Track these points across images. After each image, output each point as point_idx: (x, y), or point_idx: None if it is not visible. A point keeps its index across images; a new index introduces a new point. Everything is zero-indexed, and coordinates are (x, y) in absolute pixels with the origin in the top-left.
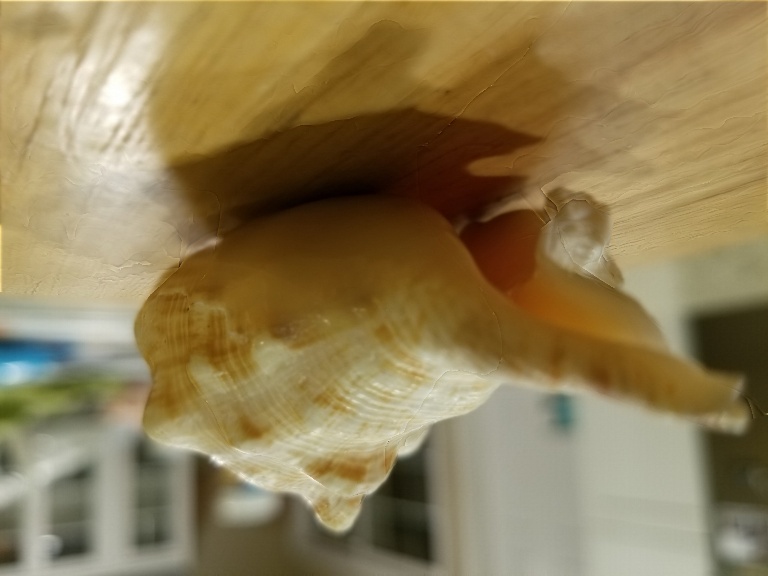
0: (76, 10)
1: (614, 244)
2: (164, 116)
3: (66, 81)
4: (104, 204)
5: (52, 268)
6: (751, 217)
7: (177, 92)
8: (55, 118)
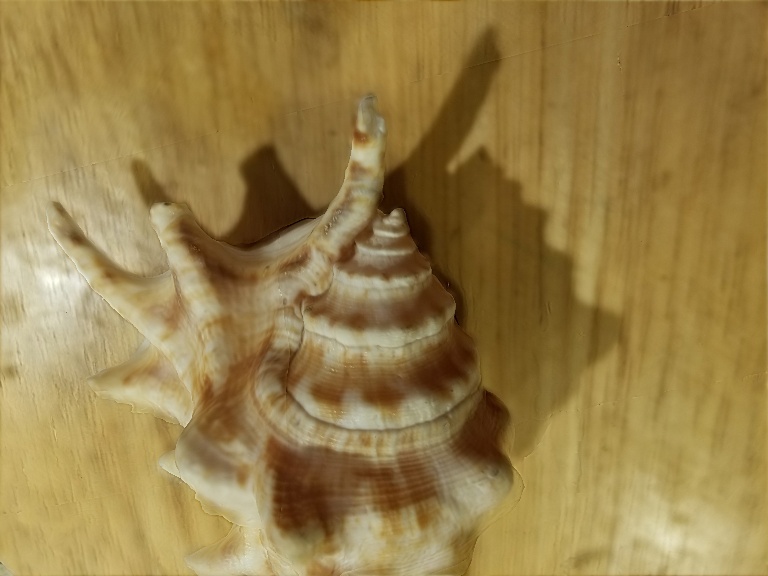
0: (558, 570)
1: (9, 393)
2: (515, 510)
3: None
4: (528, 389)
5: (551, 87)
6: (1, 500)
7: (515, 533)
8: (561, 487)
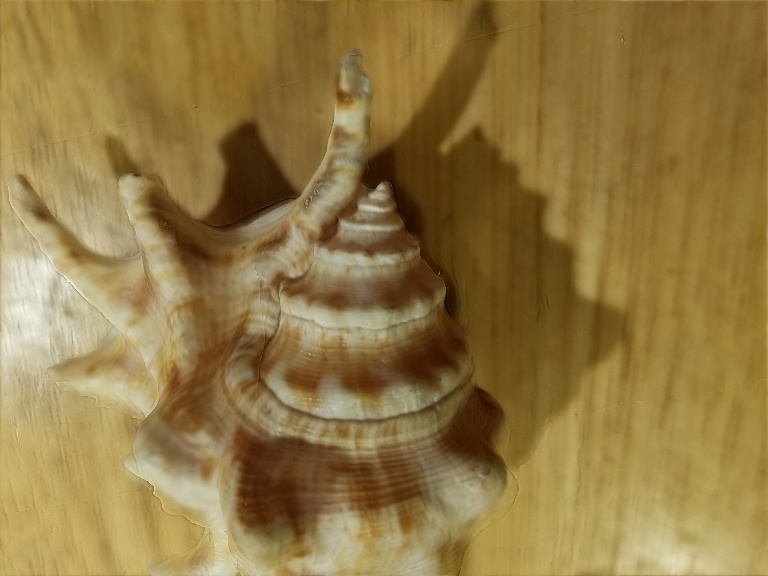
0: None
1: None
2: (510, 524)
3: (557, 546)
4: (524, 391)
5: (551, 64)
6: None
7: (510, 550)
8: (559, 499)
